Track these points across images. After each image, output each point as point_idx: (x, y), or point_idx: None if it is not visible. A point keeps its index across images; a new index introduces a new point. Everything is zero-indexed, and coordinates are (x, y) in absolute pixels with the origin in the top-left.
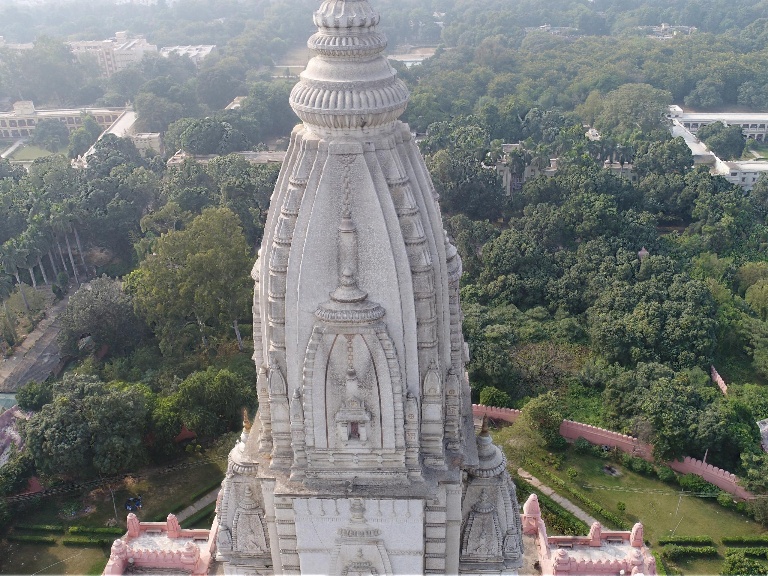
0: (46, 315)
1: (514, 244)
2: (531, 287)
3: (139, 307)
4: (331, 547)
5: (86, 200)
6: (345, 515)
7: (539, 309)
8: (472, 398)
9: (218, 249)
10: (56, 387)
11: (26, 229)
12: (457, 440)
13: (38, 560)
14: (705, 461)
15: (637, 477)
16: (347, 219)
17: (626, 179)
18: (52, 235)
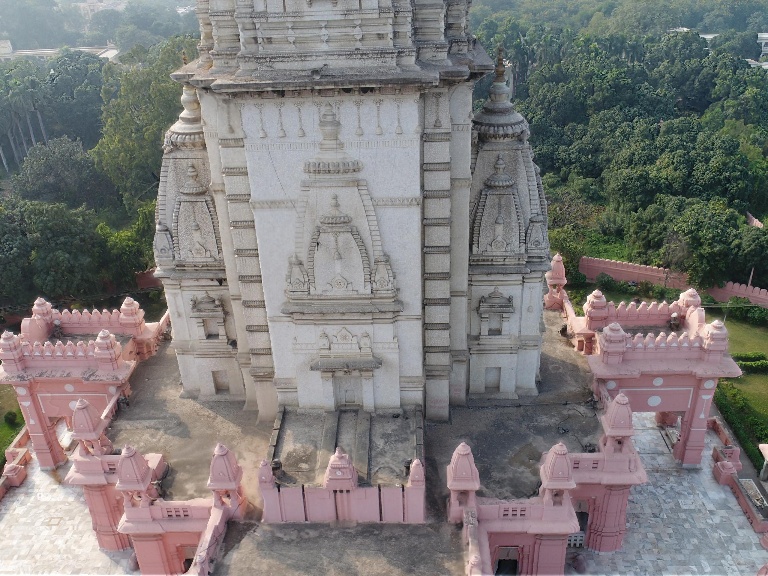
0: None
1: (520, 112)
2: (540, 154)
3: (101, 160)
4: (296, 197)
5: (51, 85)
6: (313, 137)
7: (549, 175)
8: None
9: None
10: None
11: None
12: (464, 38)
13: None
14: (750, 284)
15: None
16: None
17: (638, 64)
18: (12, 113)
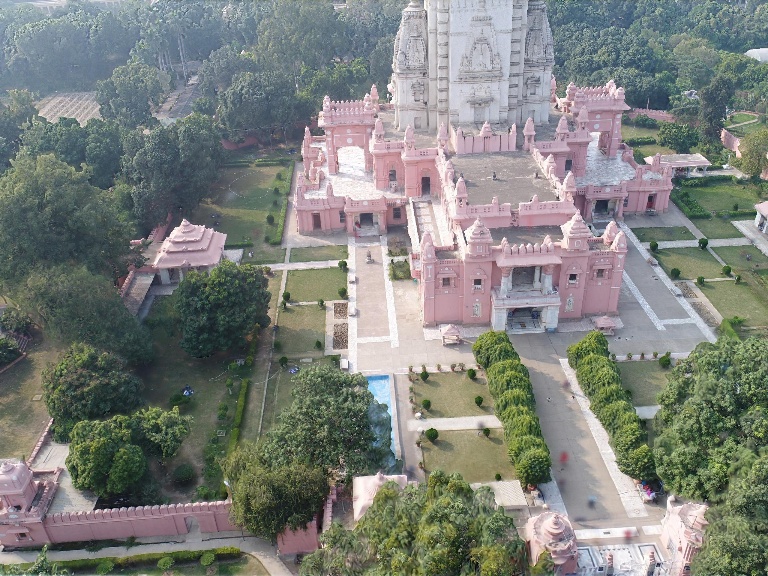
0: (169, 96)
1: None
2: None
3: None
4: (467, 30)
5: (184, 17)
6: (476, 7)
7: None
8: None
9: (319, 6)
10: (235, 78)
11: (143, 37)
12: None
13: (244, 172)
14: (648, 108)
15: None
16: None
17: None
18: None
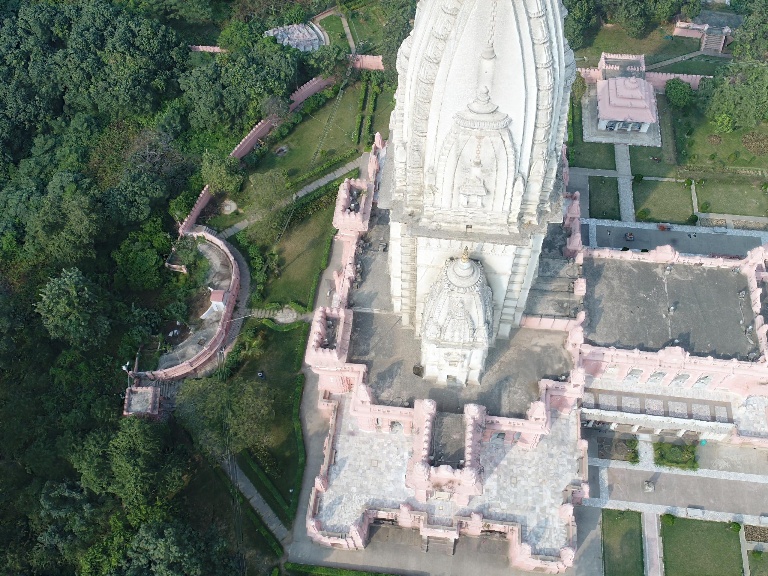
0: None
1: None
2: (7, 133)
3: None
4: None
5: None
6: None
7: (42, 140)
8: (166, 227)
9: None
10: None
11: None
12: None
13: None
14: (298, 88)
15: (291, 138)
16: (563, 6)
17: None
18: None
